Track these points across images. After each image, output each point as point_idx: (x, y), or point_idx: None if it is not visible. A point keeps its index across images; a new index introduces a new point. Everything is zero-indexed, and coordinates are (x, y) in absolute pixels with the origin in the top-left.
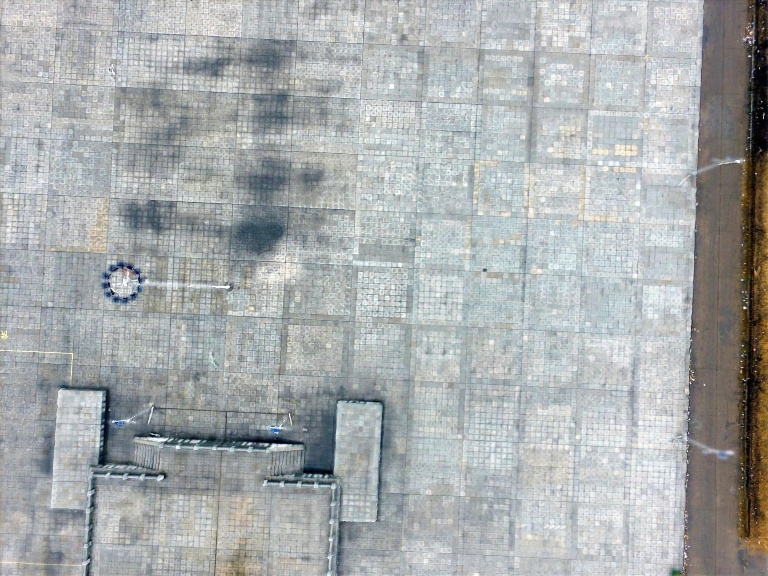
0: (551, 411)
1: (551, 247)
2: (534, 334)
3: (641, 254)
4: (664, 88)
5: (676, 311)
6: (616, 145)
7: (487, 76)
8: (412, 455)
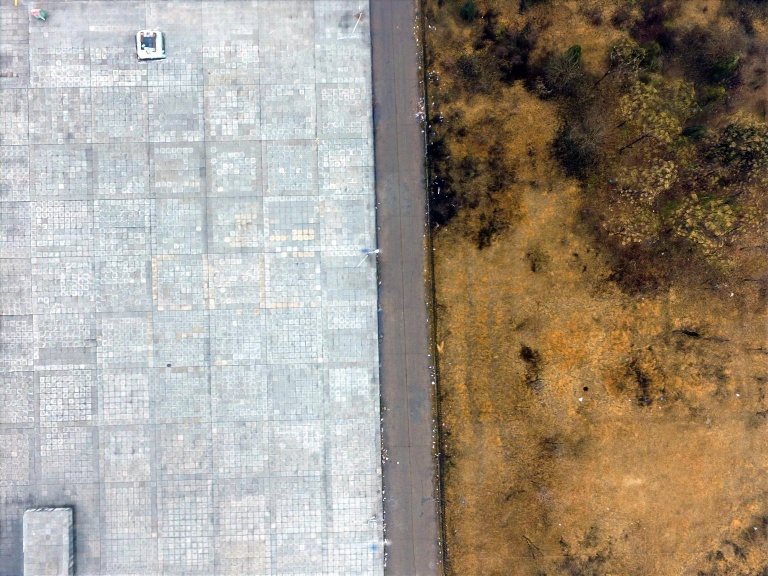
0: (244, 502)
1: (234, 337)
2: (223, 426)
3: (325, 338)
4: (337, 170)
5: (363, 392)
6: (293, 230)
7: (158, 169)
8: (106, 558)
